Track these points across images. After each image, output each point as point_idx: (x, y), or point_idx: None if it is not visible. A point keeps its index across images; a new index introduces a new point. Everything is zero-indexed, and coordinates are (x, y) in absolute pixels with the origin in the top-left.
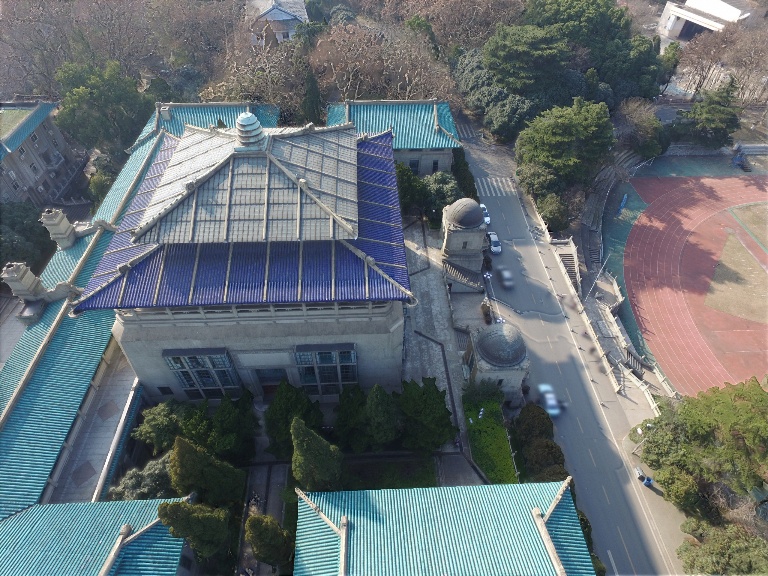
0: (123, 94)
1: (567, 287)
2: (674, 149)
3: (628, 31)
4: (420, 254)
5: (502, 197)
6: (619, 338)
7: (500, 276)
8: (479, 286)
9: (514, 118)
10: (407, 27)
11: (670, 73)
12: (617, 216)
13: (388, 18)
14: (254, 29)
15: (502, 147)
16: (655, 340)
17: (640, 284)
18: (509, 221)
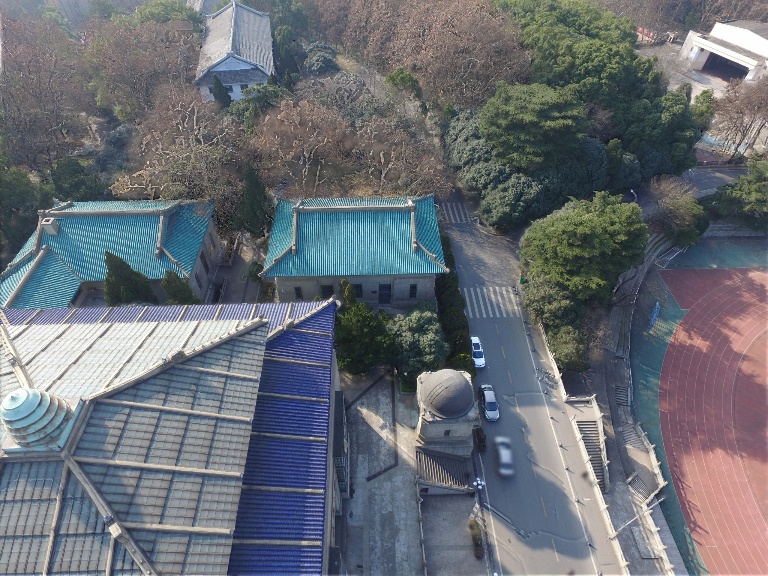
0: (5, 191)
1: (590, 485)
2: (713, 230)
3: (657, 86)
4: (385, 438)
5: (502, 320)
6: (664, 562)
7: (497, 463)
8: (467, 488)
9: (518, 207)
10: (388, 82)
11: (704, 129)
12: (648, 330)
13: (372, 59)
14: (205, 81)
15: (503, 238)
16: (709, 544)
17: (683, 443)
18: (510, 361)
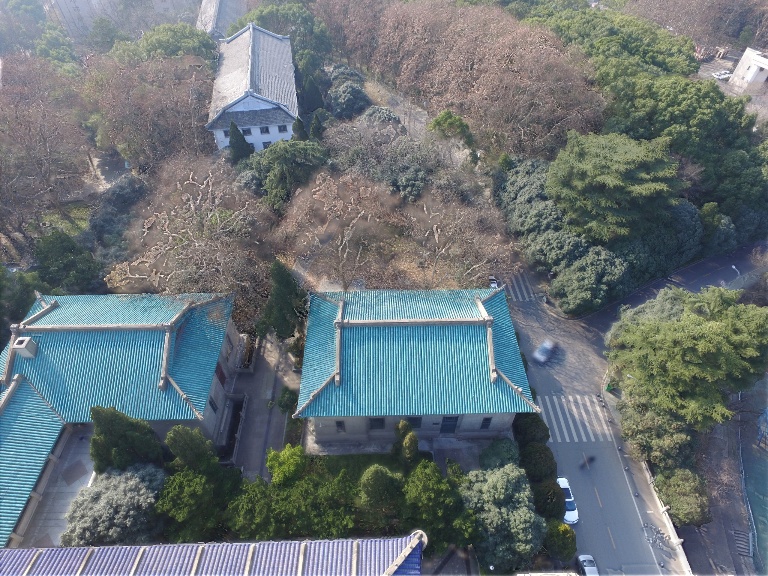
0: None
1: None
2: None
3: (750, 131)
4: None
5: (590, 446)
6: None
7: None
8: None
9: (600, 291)
10: (434, 128)
11: None
12: (758, 443)
13: (405, 90)
14: (220, 124)
15: (576, 323)
16: None
17: None
18: (609, 512)
